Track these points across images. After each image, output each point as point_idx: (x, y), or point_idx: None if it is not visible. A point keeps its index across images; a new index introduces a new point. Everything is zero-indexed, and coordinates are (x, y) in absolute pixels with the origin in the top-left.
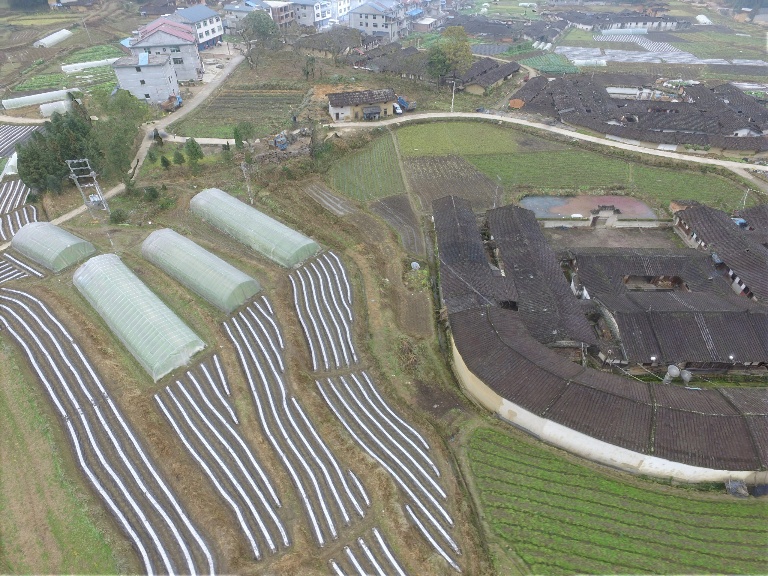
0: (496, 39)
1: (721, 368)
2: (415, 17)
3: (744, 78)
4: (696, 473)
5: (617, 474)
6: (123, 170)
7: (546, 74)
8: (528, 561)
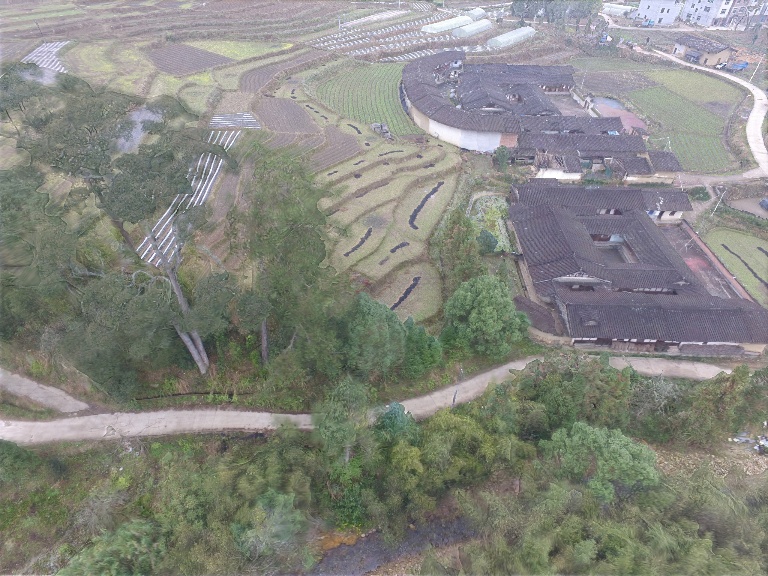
0: None
1: None
2: None
3: None
4: None
5: None
6: (520, 7)
7: None
8: None
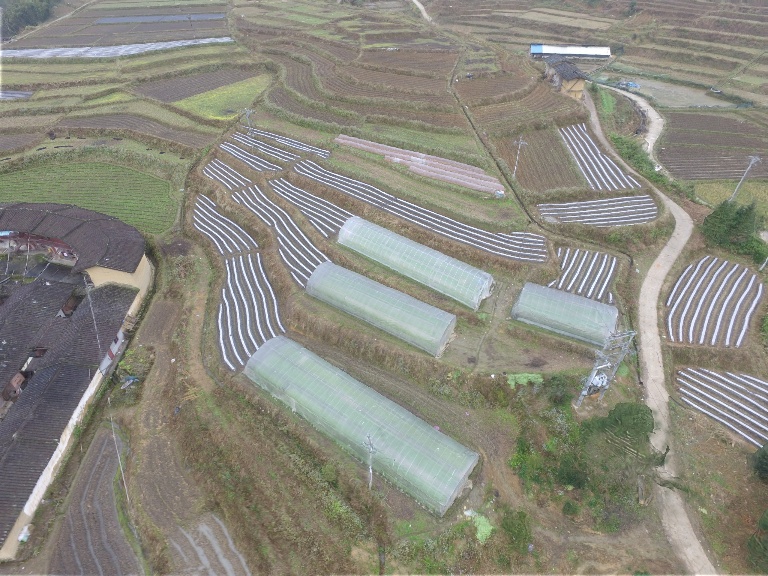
0: None
1: None
2: None
3: None
4: None
5: None
6: None
7: None
8: None
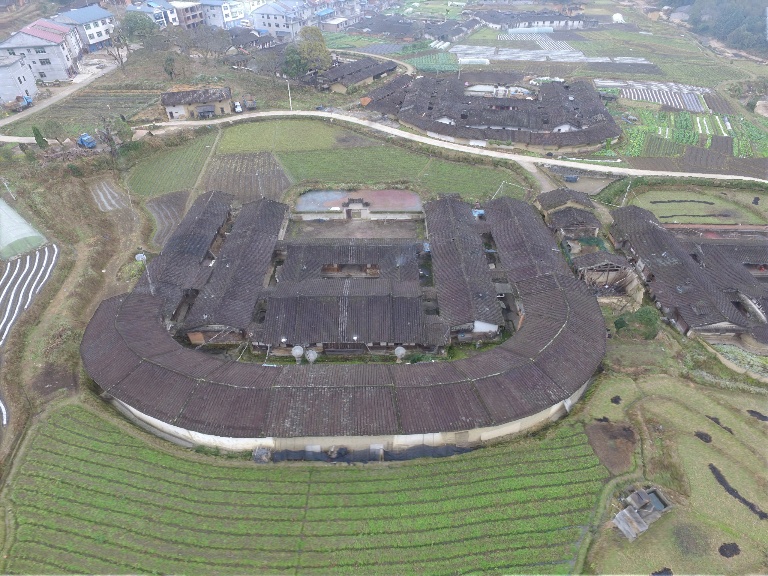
0: (397, 38)
1: (358, 349)
2: (325, 17)
3: (614, 75)
4: (230, 442)
5: (161, 444)
6: None
7: (423, 73)
8: (19, 522)
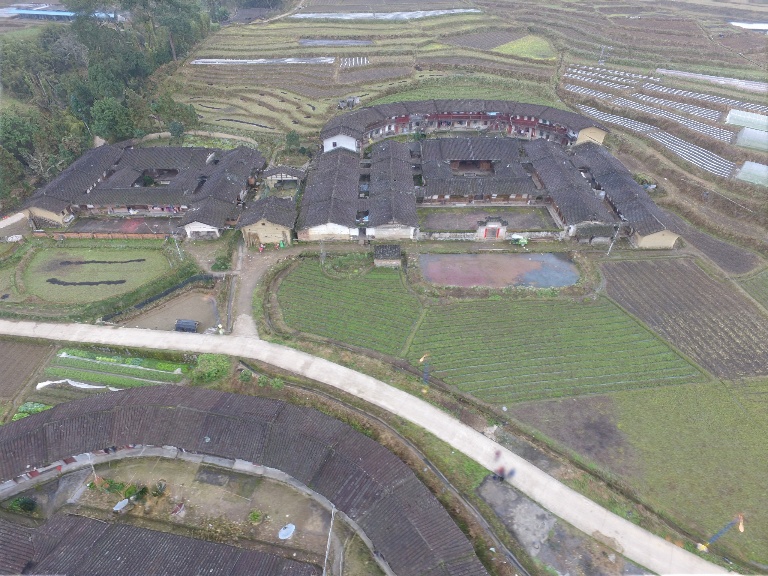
0: None
1: None
2: None
3: None
4: None
5: None
6: None
7: None
8: None
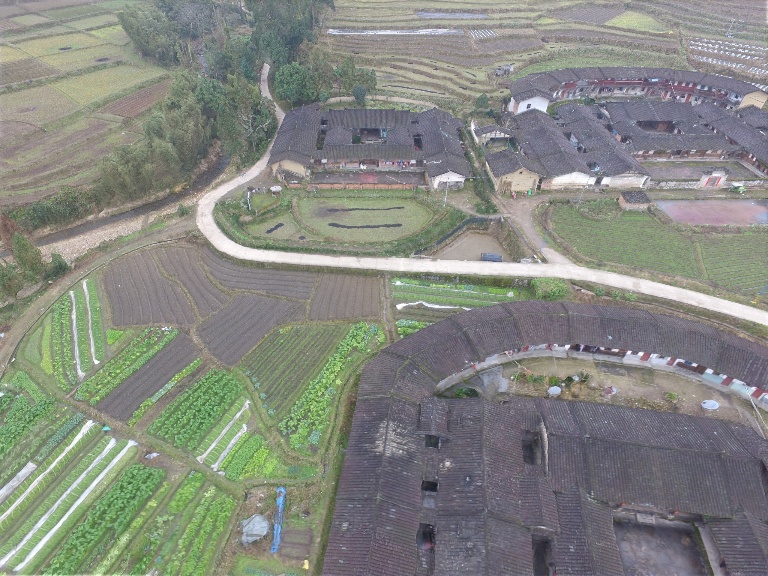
0: None
1: None
2: None
3: None
4: None
5: None
6: None
7: None
8: None
